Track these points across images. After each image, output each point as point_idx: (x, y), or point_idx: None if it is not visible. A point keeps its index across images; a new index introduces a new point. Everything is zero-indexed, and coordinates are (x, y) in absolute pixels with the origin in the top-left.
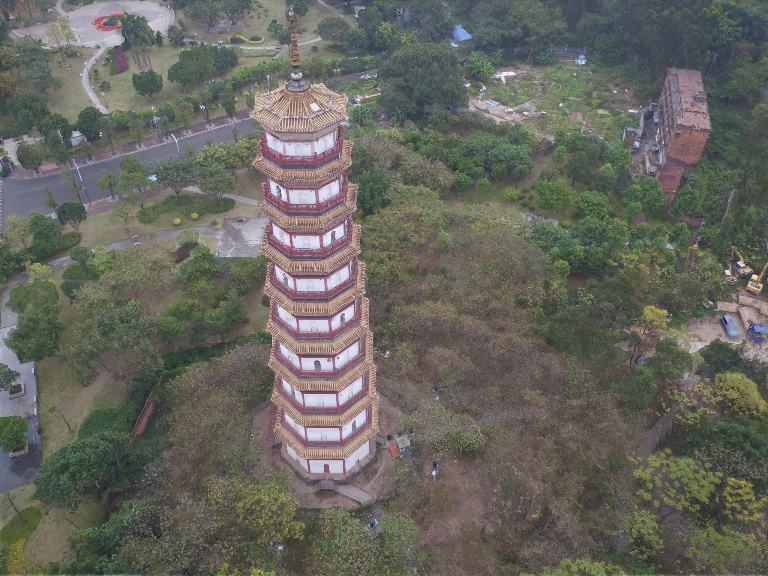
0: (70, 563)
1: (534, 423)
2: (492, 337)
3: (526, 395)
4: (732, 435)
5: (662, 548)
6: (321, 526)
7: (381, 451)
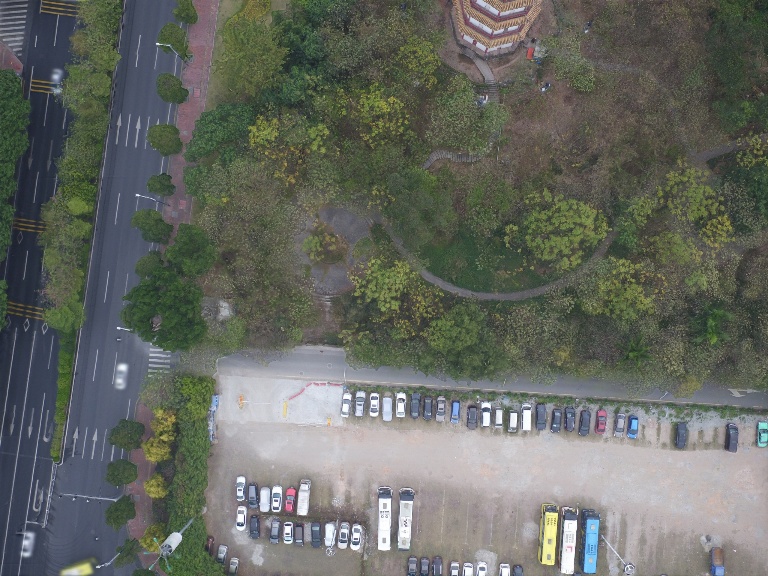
0: (288, 21)
1: (632, 100)
2: (666, 3)
3: (642, 77)
4: (761, 189)
5: (642, 225)
6: (448, 84)
7: (521, 48)
